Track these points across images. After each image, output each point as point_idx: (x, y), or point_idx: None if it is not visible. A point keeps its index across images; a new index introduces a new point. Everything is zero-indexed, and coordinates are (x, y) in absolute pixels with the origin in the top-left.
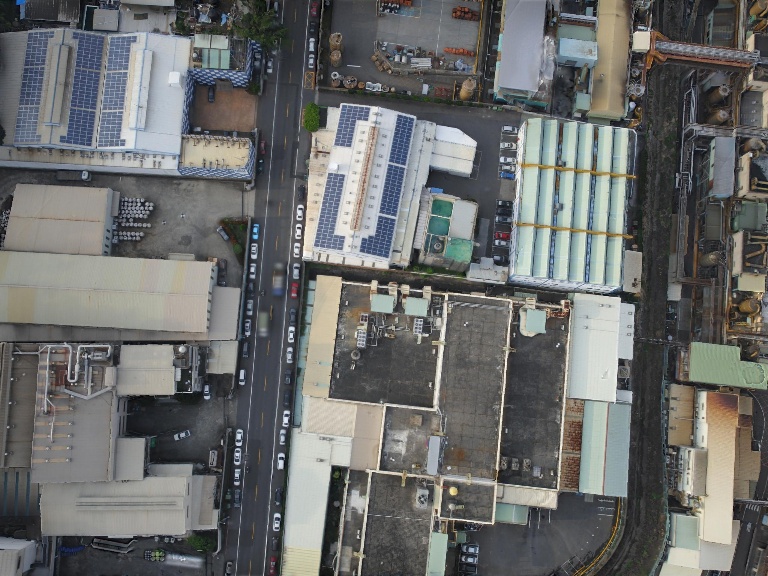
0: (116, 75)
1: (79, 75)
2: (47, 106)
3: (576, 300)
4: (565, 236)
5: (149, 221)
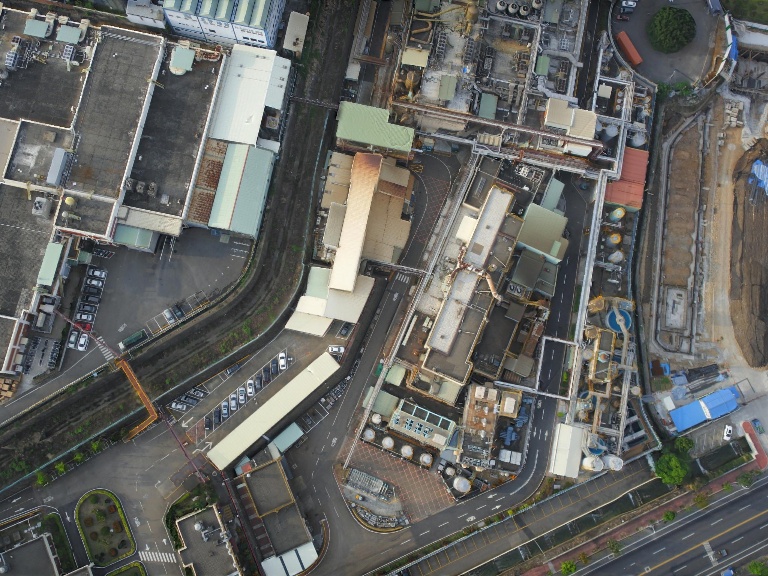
0: None
1: None
2: None
3: (234, 50)
4: None
5: None
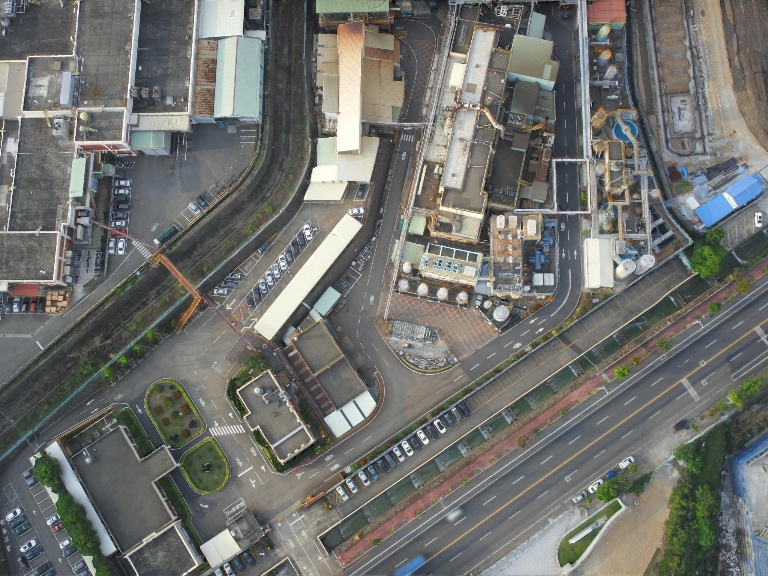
0: None
1: None
2: None
3: None
4: None
5: None
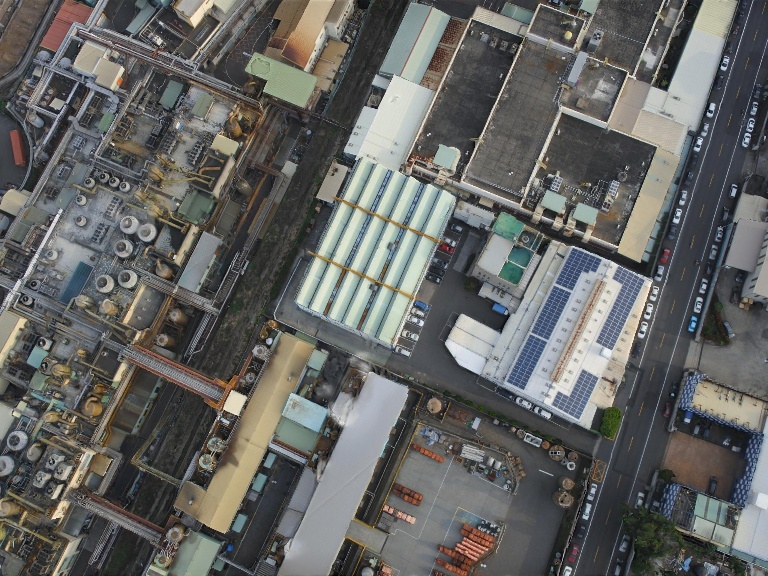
0: None
1: None
2: None
3: None
4: (397, 217)
5: None
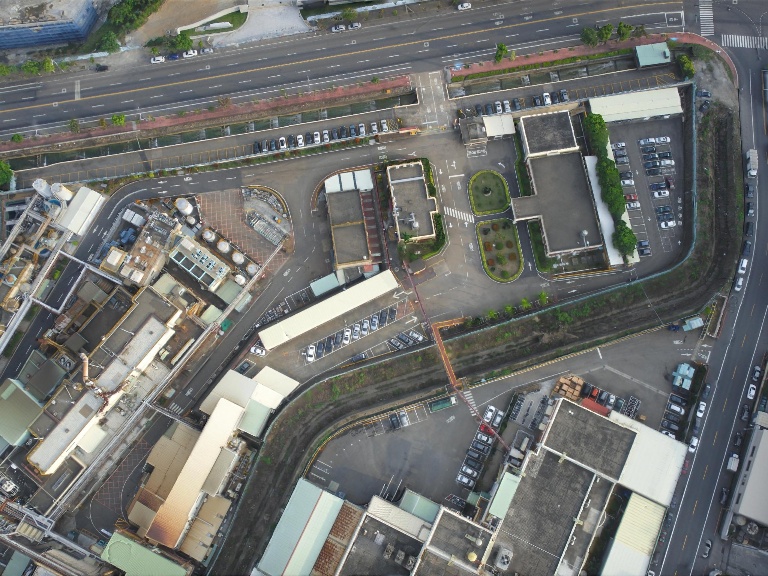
0: None
1: None
2: None
3: None
4: None
5: None
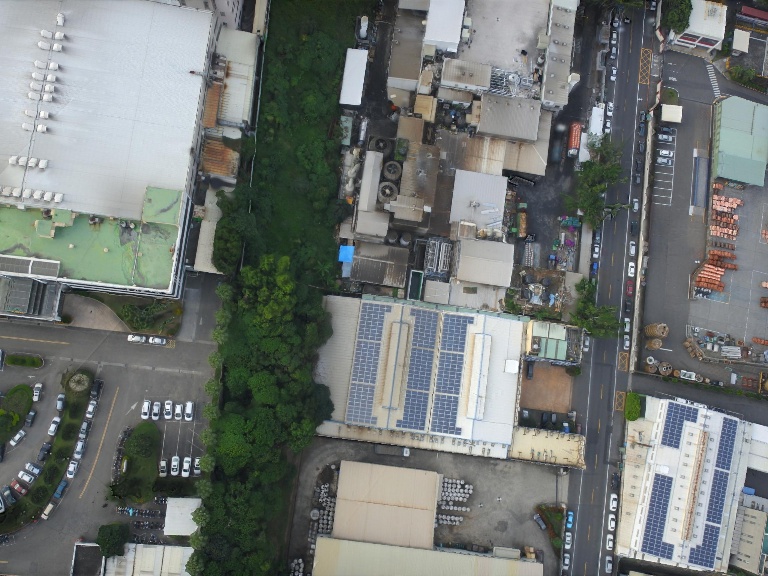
0: (451, 356)
1: (415, 354)
2: (386, 388)
3: None
4: None
5: (466, 503)
